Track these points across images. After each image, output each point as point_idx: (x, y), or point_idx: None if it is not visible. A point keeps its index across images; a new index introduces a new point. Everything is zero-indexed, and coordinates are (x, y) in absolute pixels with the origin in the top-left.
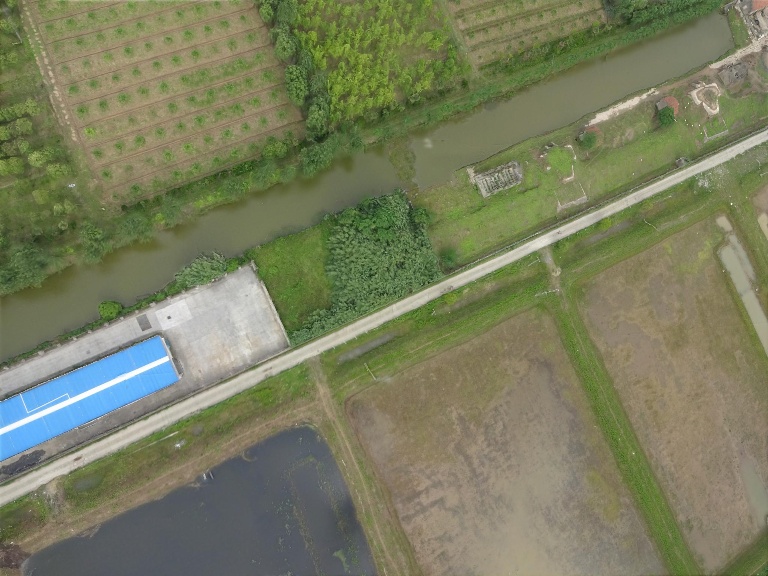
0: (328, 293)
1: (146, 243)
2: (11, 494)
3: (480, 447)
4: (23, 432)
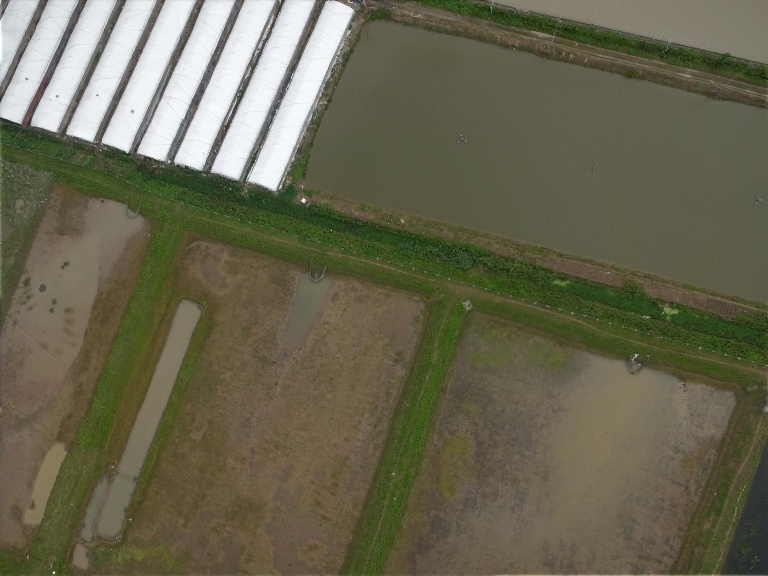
0: None
1: None
2: None
3: None
4: None
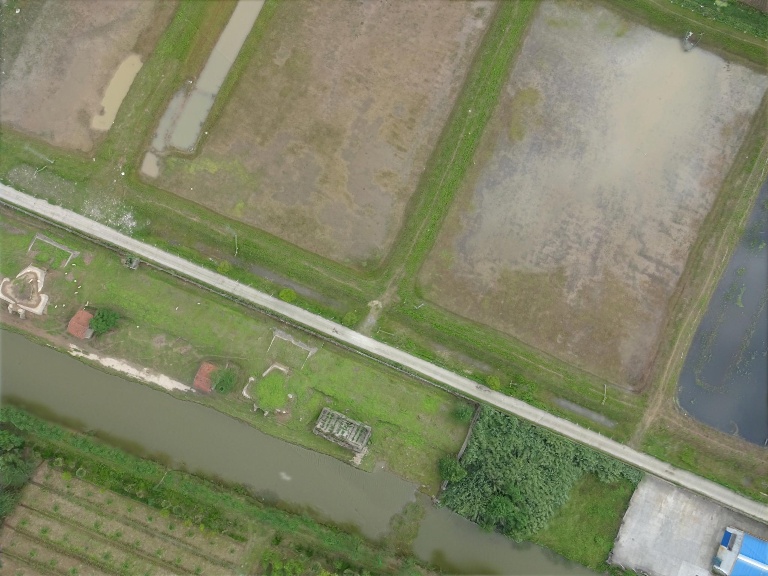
0: (578, 483)
1: None
2: None
3: (577, 254)
4: None
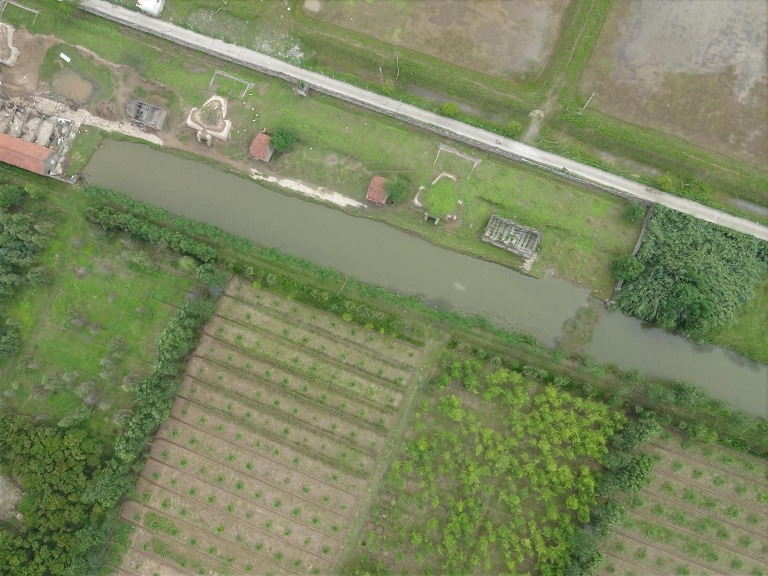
0: (762, 281)
1: None
2: None
3: (747, 51)
4: None
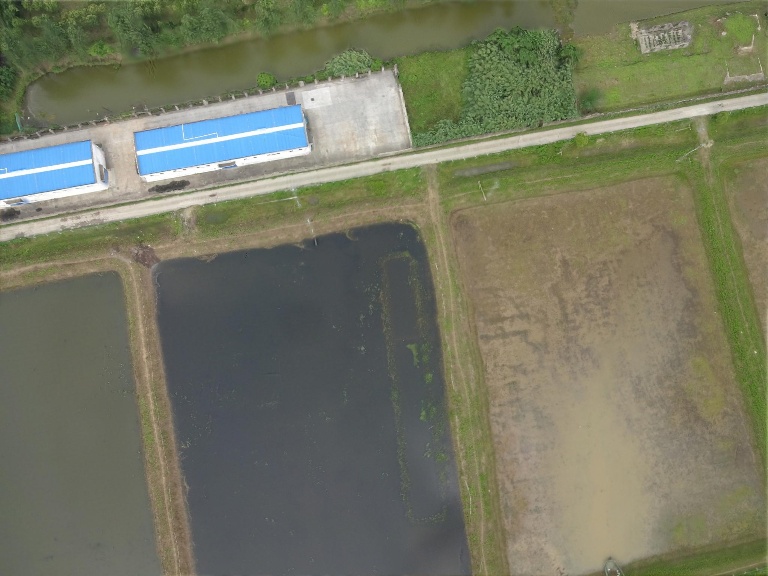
0: (459, 109)
1: (308, 27)
2: (157, 208)
3: (578, 295)
4: (177, 154)
